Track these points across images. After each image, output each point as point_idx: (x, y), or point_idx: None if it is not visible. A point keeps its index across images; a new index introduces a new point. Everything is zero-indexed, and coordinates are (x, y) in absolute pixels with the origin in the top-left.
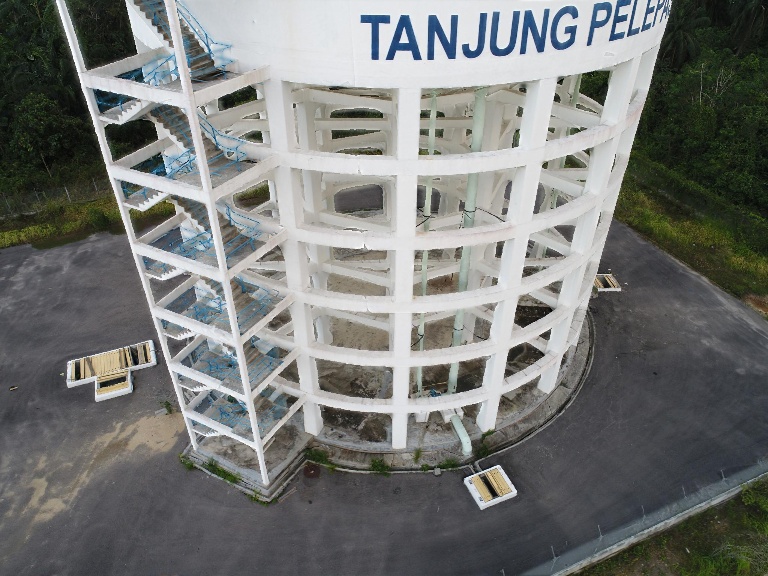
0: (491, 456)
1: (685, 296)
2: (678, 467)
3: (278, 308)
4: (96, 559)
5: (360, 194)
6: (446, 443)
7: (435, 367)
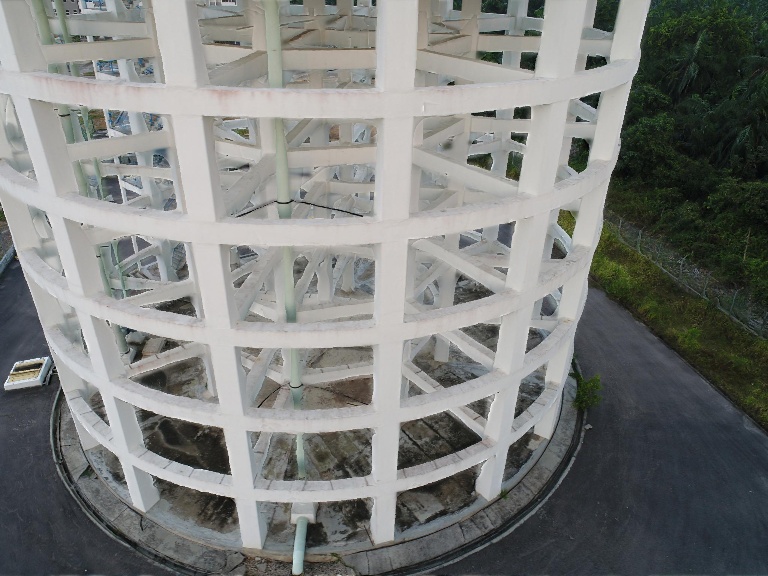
0: (59, 385)
1: None
2: None
3: None
4: None
5: (631, 362)
6: None
7: (192, 361)
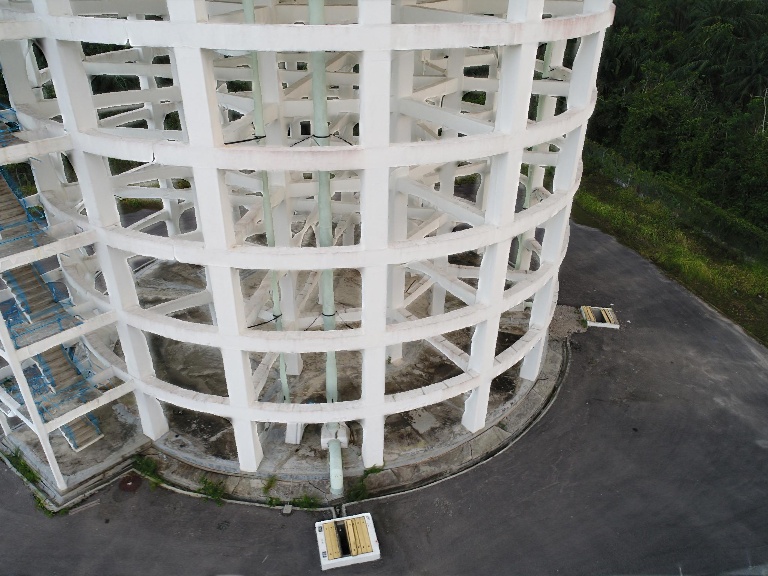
0: (368, 501)
1: (705, 344)
2: (633, 559)
3: (63, 243)
4: None
5: None
6: (311, 474)
7: (341, 382)
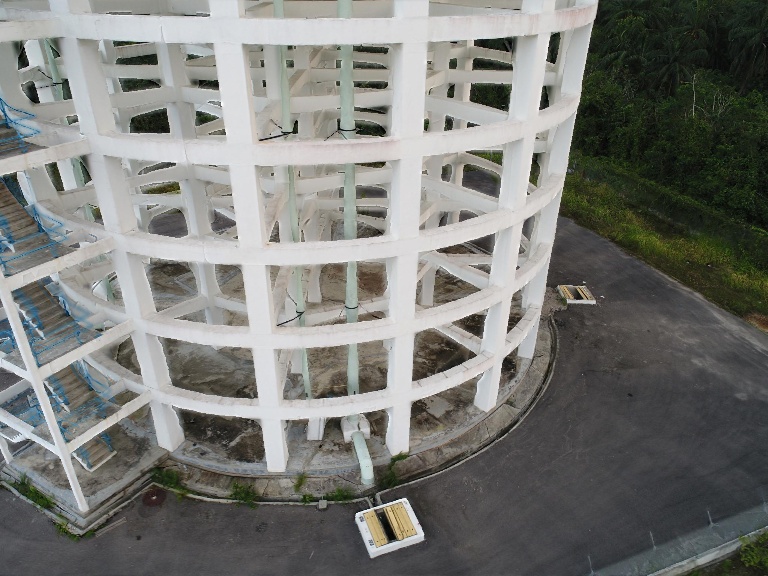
0: (399, 487)
1: (673, 312)
2: (653, 512)
3: (82, 252)
4: None
5: None
6: (340, 467)
7: None
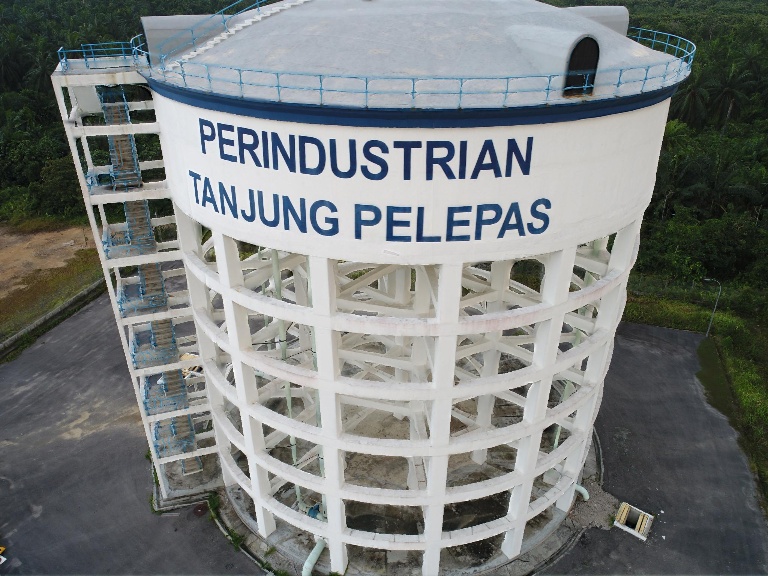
0: None
1: None
2: None
3: (181, 364)
4: (57, 478)
5: None
6: (296, 557)
7: None
